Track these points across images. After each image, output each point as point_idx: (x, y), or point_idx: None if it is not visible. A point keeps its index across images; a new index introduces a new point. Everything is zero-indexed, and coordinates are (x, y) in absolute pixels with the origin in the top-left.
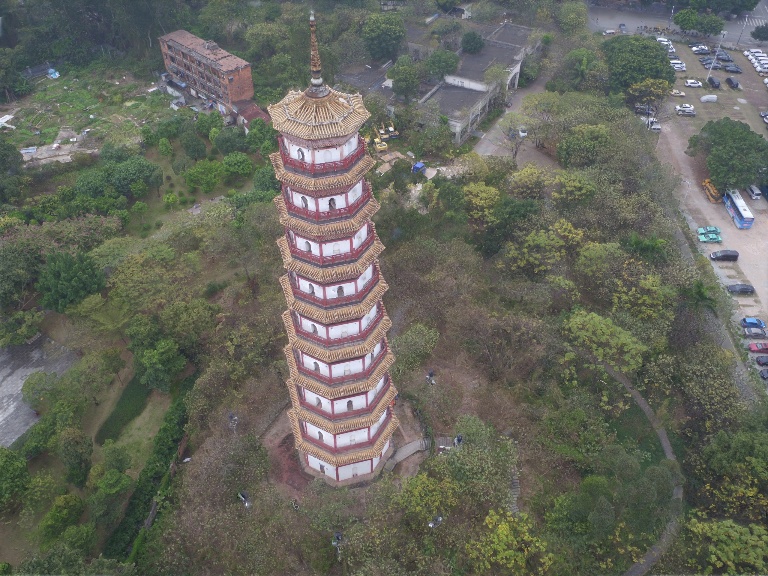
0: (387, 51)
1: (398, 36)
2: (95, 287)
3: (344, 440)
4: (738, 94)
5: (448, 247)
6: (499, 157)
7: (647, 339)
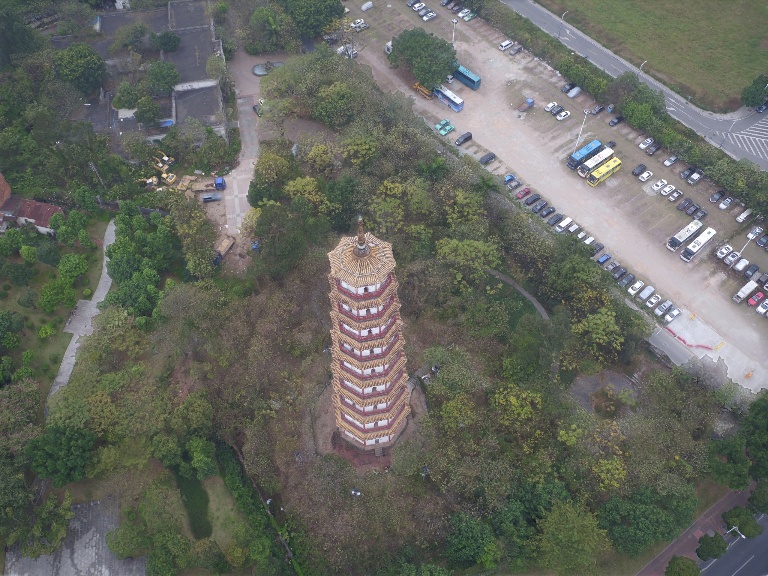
0: (95, 82)
1: (99, 65)
2: (92, 443)
3: None
4: None
5: (329, 246)
6: (276, 142)
7: (481, 235)
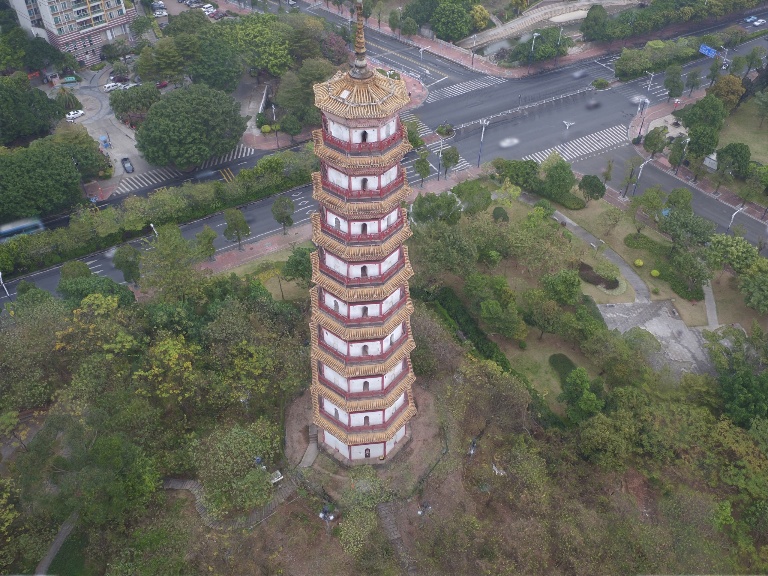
0: None
1: None
2: (727, 405)
3: None
4: None
5: None
6: None
7: None
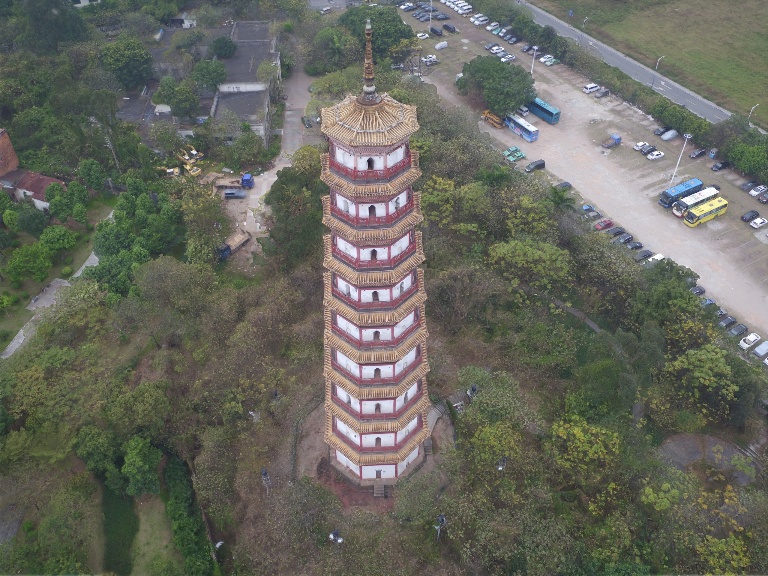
0: (140, 78)
1: (147, 59)
2: (3, 425)
3: (401, 434)
4: (459, 36)
5: None
6: (318, 145)
7: None
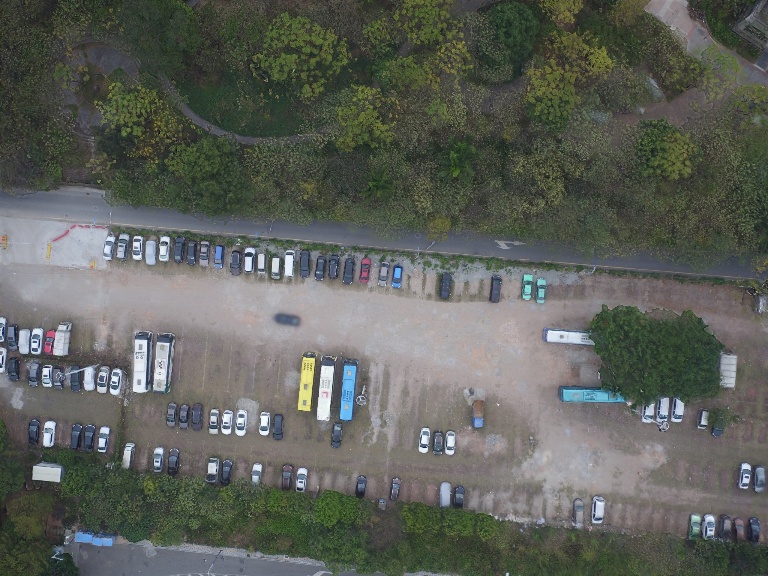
0: None
1: None
2: None
3: None
4: None
5: None
6: None
7: None
